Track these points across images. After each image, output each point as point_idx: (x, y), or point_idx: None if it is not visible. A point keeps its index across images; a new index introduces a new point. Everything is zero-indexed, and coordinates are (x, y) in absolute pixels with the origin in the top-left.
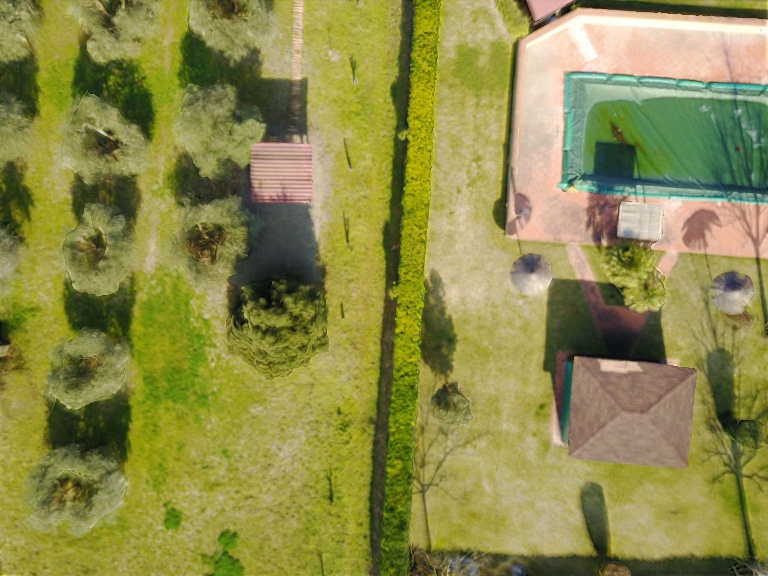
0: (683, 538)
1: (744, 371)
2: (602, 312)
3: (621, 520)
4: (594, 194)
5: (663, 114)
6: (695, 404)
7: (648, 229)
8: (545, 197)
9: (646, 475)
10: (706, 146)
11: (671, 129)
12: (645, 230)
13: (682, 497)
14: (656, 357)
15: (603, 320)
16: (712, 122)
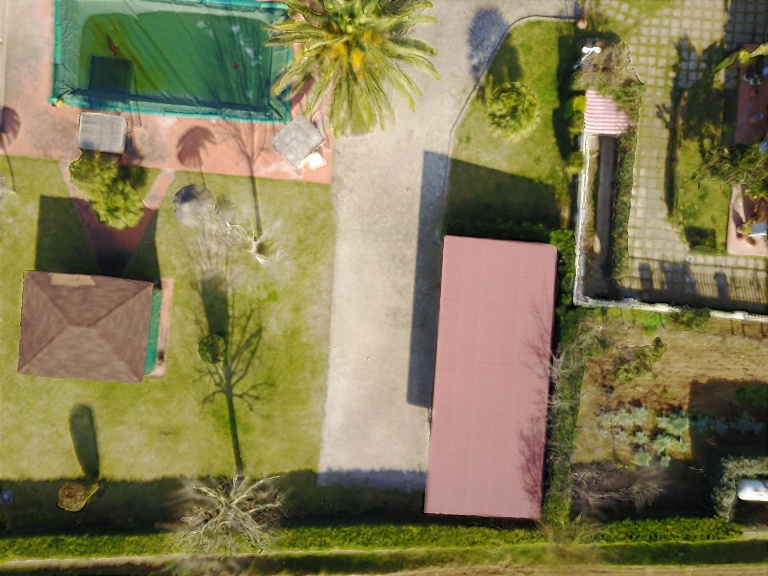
0: (172, 458)
1: (237, 290)
2: (96, 231)
3: (109, 442)
4: (87, 109)
5: (162, 29)
6: (188, 324)
7: (110, 141)
8: (36, 112)
9: (137, 396)
10: (206, 63)
11: (171, 45)
12: (106, 142)
13: (172, 417)
14: (150, 277)
15: (97, 239)
16: (211, 38)
